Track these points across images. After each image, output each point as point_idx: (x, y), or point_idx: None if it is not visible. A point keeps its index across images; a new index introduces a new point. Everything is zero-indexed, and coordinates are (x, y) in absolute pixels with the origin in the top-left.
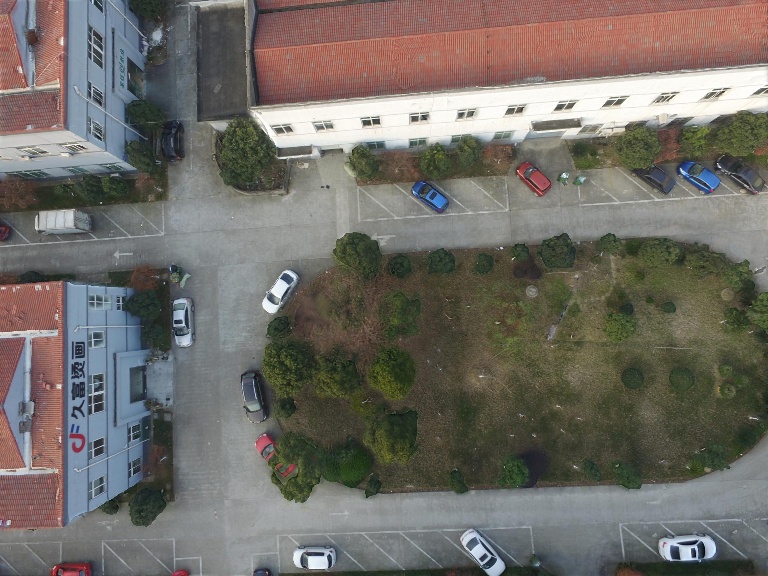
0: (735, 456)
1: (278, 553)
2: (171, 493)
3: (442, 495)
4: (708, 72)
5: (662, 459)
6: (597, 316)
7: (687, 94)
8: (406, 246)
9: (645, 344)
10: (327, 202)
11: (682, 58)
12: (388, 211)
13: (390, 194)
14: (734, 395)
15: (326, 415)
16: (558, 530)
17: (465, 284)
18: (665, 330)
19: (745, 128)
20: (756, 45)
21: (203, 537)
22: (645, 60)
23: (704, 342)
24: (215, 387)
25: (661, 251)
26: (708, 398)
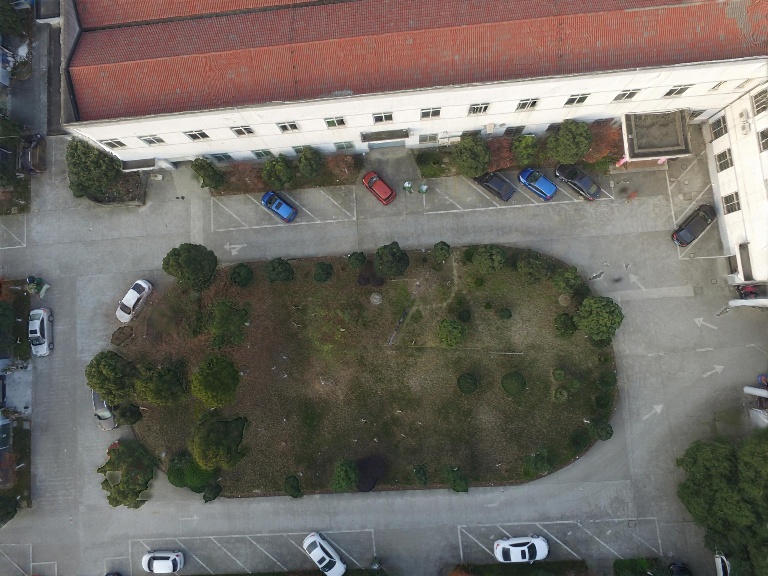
0: (571, 459)
1: (130, 557)
2: (29, 499)
3: (288, 499)
4: (500, 85)
5: (499, 462)
6: (438, 322)
7: (498, 105)
8: (257, 255)
9: (484, 349)
10: (182, 213)
11: (482, 71)
12: (240, 221)
13: (242, 204)
14: (566, 399)
15: (176, 422)
16: (399, 533)
17: (312, 292)
18: (504, 335)
19: (567, 137)
20: (554, 57)
21: (58, 542)
22: (446, 73)
23: (541, 347)
24: (72, 395)
25: (485, 258)
26: (544, 402)
